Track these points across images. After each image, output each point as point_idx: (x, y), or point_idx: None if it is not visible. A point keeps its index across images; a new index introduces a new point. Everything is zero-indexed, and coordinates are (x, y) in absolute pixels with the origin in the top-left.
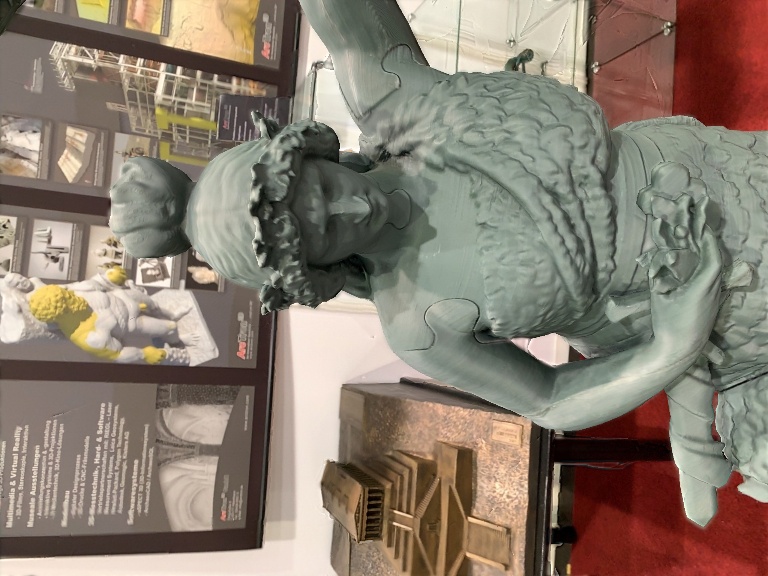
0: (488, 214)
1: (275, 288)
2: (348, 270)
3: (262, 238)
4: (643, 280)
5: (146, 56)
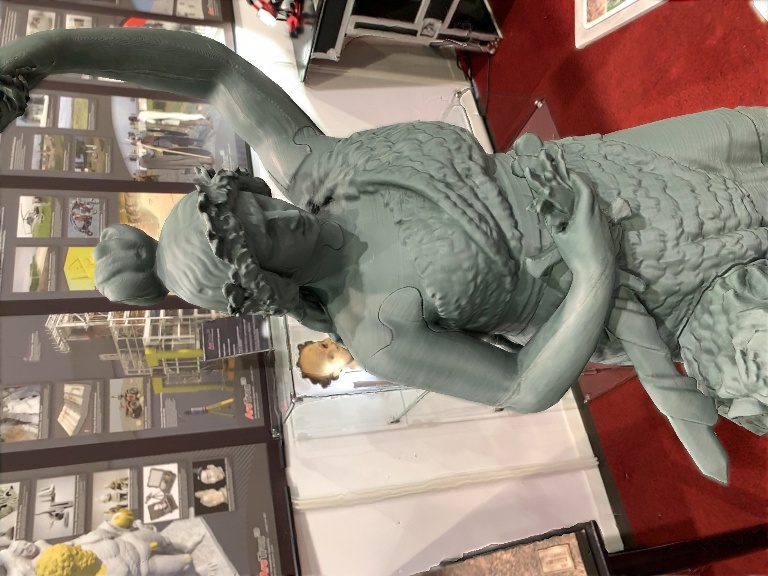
0: (401, 213)
1: (234, 284)
2: (307, 304)
3: (212, 228)
4: (550, 242)
5: (131, 308)
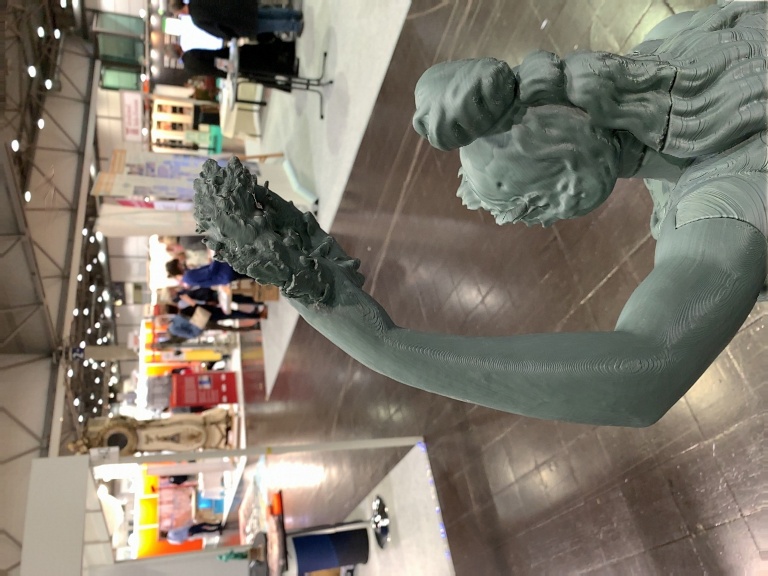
0: None
1: None
2: None
3: None
4: None
5: None
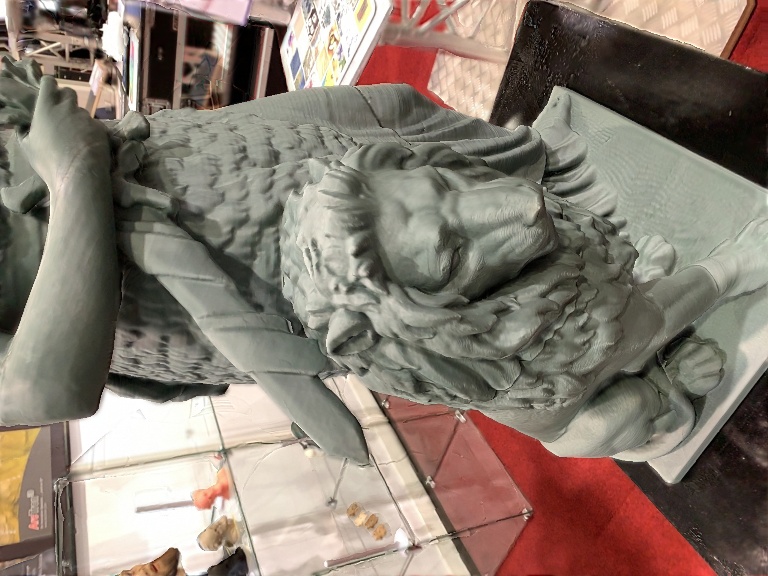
0: None
1: None
2: None
3: None
4: None
5: None
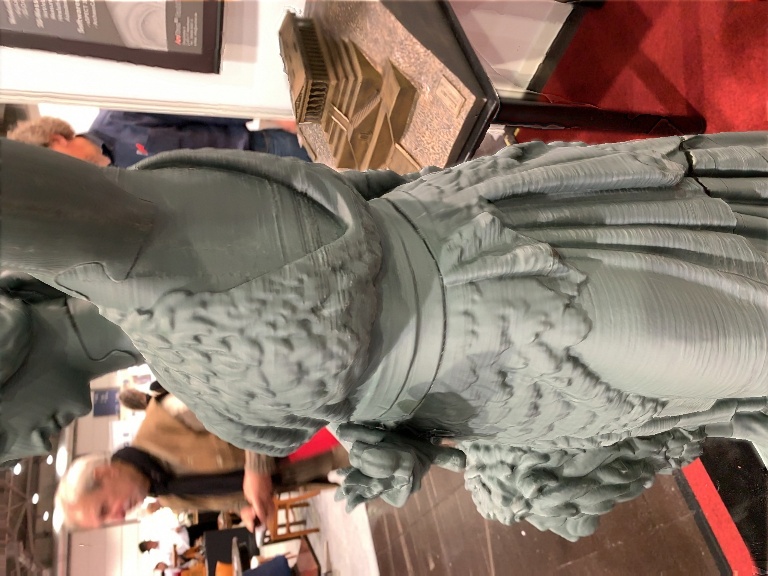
0: None
1: None
2: None
3: None
4: None
5: None
